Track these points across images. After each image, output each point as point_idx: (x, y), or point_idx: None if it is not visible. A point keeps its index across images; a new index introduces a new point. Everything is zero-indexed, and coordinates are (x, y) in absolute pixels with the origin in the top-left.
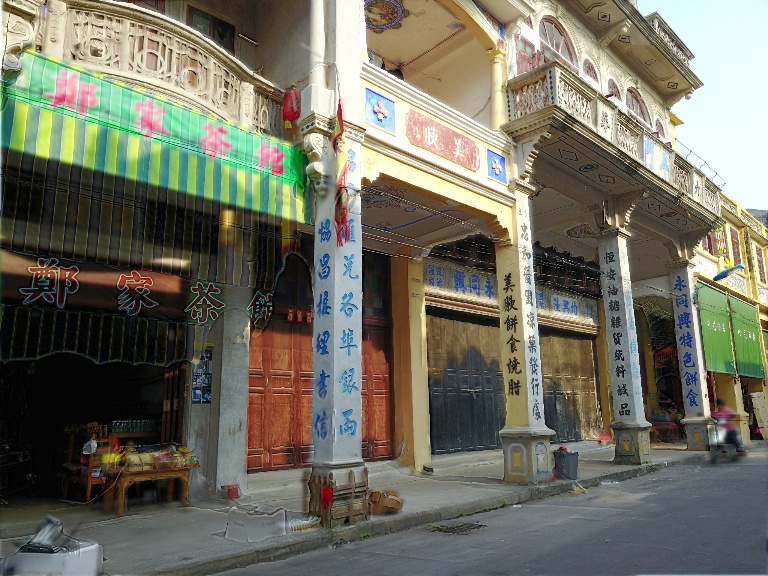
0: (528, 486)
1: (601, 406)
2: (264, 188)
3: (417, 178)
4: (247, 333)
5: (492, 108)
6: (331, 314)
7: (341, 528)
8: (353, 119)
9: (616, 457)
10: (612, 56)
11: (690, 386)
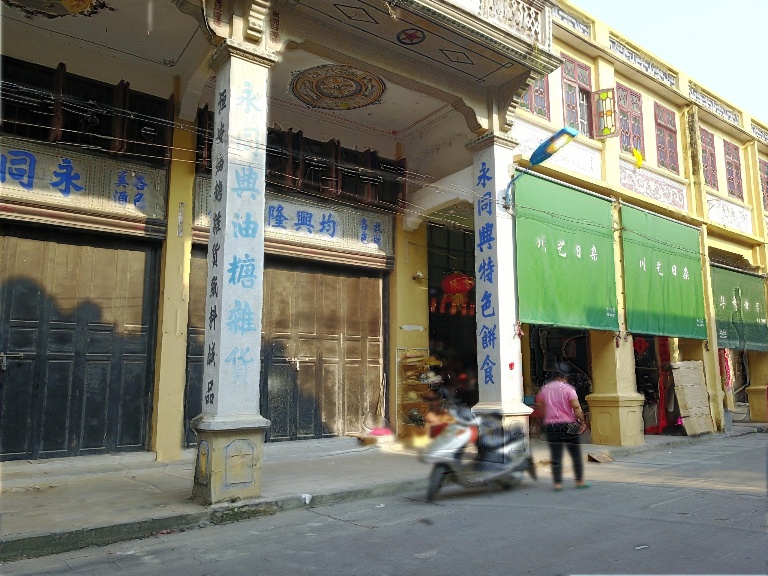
0: None
1: (388, 381)
2: None
3: None
4: None
5: None
6: None
7: None
8: None
9: None
10: None
11: (486, 349)
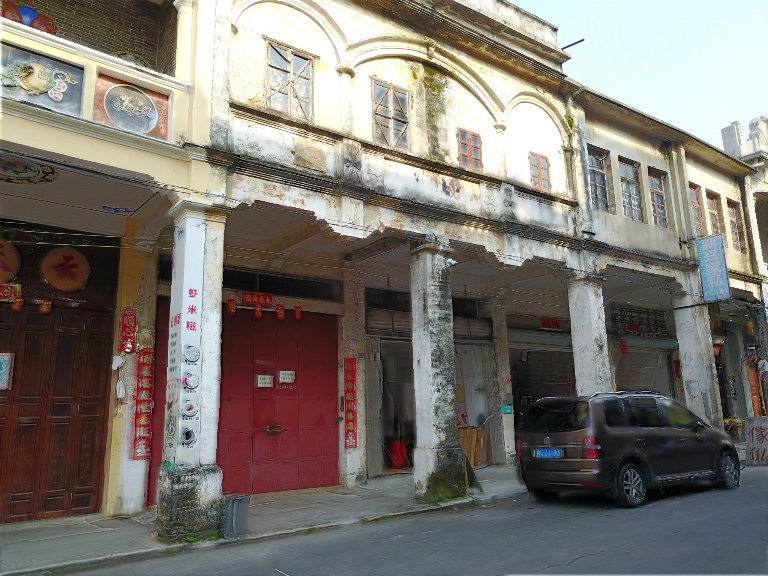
0: None
1: None
2: None
3: None
4: None
5: None
6: None
7: None
8: None
9: None
10: None
11: None
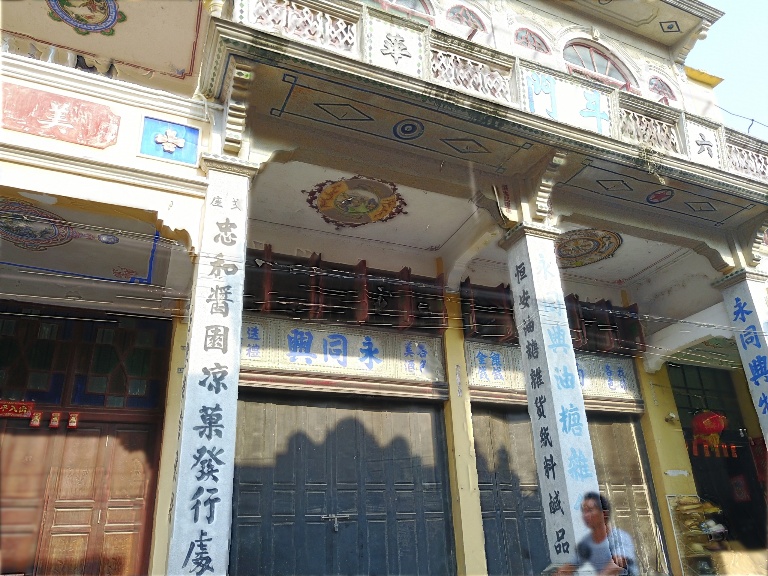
0: None
1: (663, 533)
2: None
3: None
4: None
5: None
6: None
7: None
8: None
9: None
10: (527, 2)
11: None
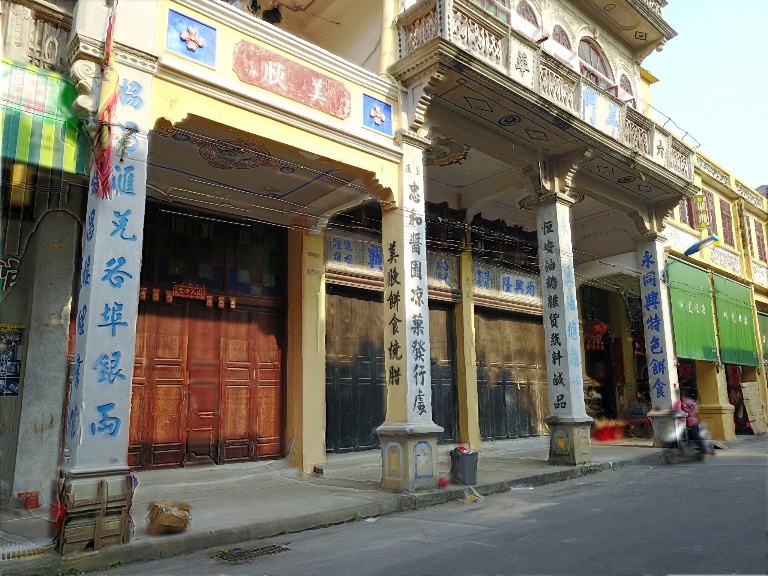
0: (401, 494)
1: None
2: (11, 128)
3: (249, 122)
4: (66, 313)
5: (380, 48)
6: (90, 284)
7: (77, 554)
8: (141, 44)
9: (550, 456)
10: None
11: (657, 375)
